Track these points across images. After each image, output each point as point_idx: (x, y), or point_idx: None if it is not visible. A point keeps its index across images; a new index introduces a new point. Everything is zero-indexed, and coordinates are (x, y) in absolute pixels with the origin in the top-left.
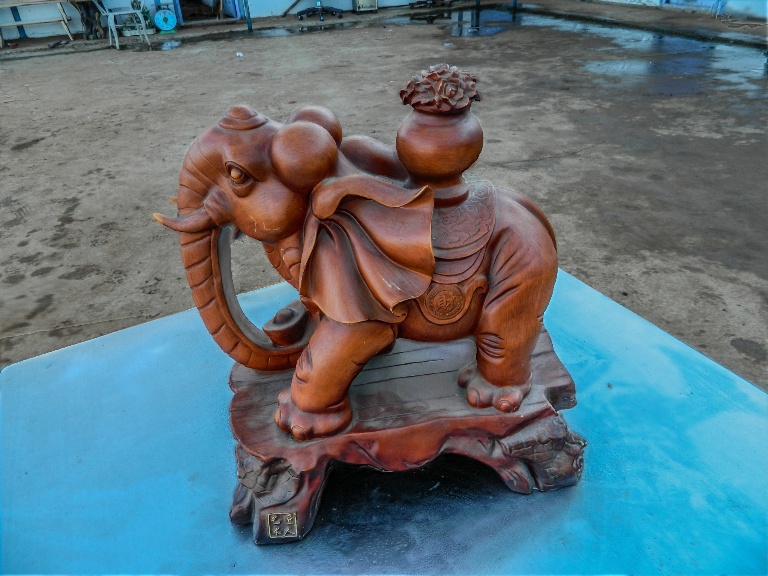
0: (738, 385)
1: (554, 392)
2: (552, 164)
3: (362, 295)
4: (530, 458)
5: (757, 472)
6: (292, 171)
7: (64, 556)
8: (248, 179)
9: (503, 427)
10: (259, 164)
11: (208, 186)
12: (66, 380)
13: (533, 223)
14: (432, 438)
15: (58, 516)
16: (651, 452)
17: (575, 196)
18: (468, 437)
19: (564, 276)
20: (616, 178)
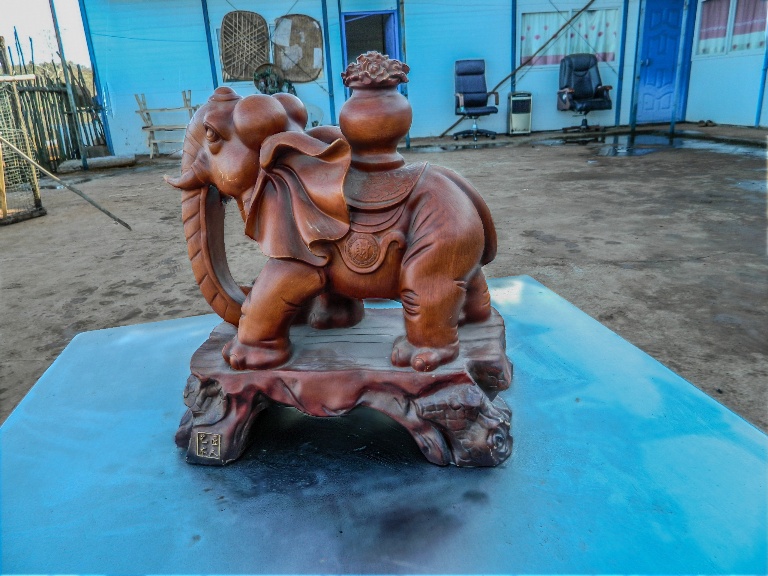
0: (725, 417)
1: (479, 366)
2: (671, 266)
3: (293, 238)
4: (443, 424)
5: (701, 487)
6: (242, 126)
7: (47, 447)
8: (219, 138)
9: (416, 385)
10: (225, 125)
11: (197, 149)
12: (116, 344)
13: (455, 193)
14: (350, 387)
15: (58, 423)
16: (590, 454)
17: (688, 296)
18: (385, 393)
19: (583, 317)
20: (742, 284)
